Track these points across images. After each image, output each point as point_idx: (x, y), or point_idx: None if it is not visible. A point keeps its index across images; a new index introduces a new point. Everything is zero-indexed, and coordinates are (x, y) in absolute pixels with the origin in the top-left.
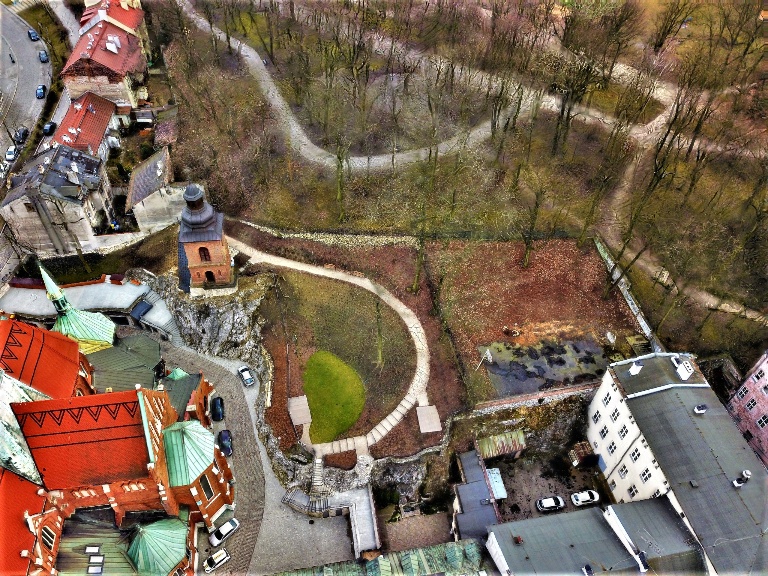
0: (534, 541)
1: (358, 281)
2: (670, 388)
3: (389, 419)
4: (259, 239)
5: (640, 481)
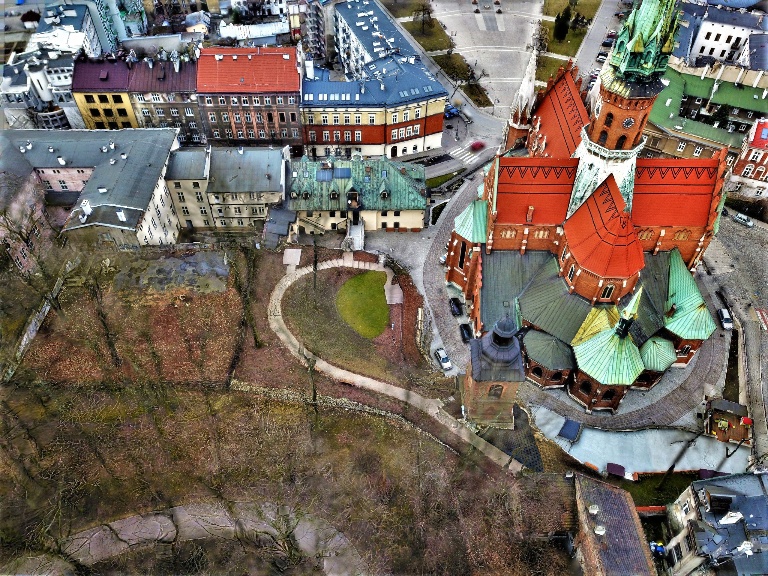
0: (259, 176)
1: (318, 363)
2: (109, 204)
3: (322, 267)
4: (432, 426)
5: (165, 207)
